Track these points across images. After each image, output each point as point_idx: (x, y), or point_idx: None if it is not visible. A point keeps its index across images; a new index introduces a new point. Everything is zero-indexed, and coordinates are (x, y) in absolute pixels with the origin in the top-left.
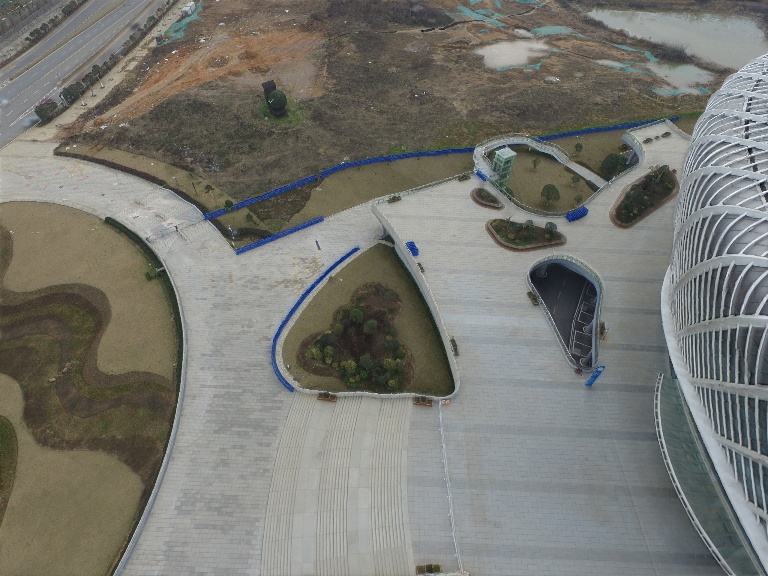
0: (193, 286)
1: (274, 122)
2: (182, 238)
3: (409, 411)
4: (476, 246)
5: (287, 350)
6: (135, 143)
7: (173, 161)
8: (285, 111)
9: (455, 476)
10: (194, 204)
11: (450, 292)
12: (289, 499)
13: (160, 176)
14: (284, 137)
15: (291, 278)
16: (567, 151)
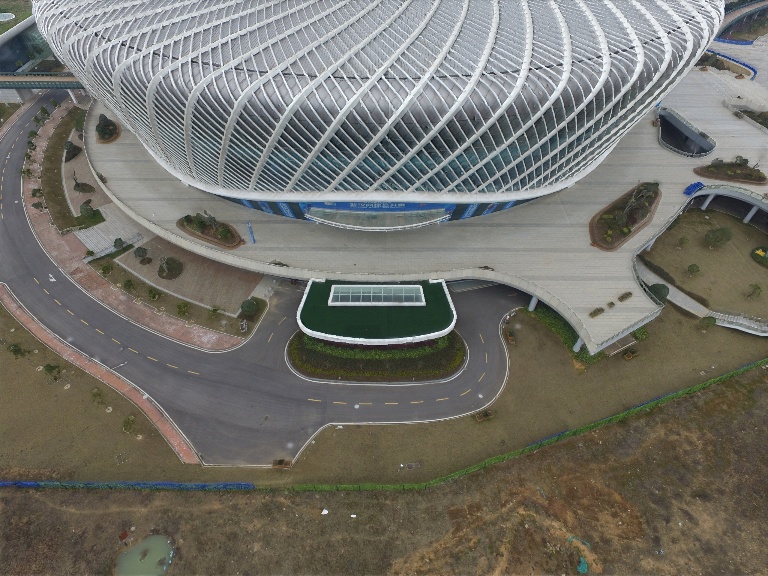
0: None
1: None
2: None
3: None
4: (764, 165)
5: None
6: None
7: None
8: None
9: None
10: None
11: (760, 138)
12: (765, 92)
13: None
14: None
15: None
16: (717, 337)
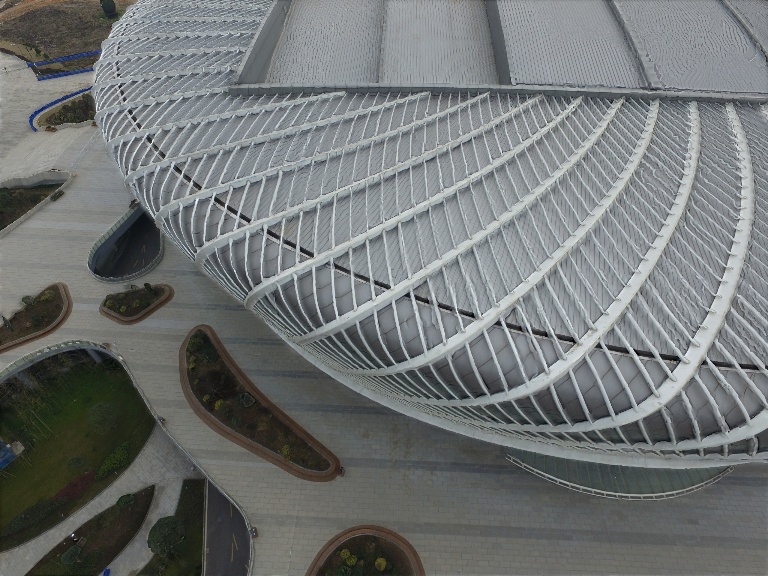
0: (1, 93)
1: (106, 21)
2: (7, 74)
3: (87, 128)
4: None
5: (43, 116)
6: (4, 34)
7: (26, 43)
8: (114, 13)
9: (94, 148)
10: (26, 60)
11: None
12: (6, 162)
13: (13, 50)
14: (108, 28)
15: (67, 91)
16: None
